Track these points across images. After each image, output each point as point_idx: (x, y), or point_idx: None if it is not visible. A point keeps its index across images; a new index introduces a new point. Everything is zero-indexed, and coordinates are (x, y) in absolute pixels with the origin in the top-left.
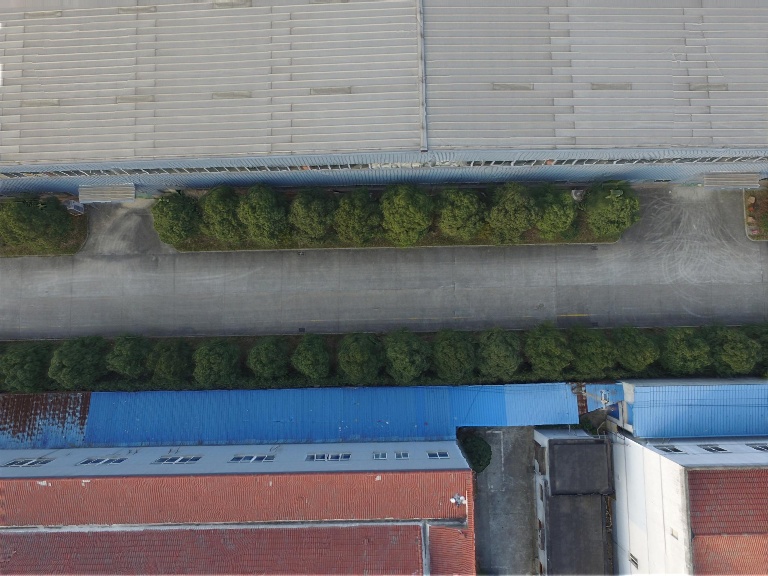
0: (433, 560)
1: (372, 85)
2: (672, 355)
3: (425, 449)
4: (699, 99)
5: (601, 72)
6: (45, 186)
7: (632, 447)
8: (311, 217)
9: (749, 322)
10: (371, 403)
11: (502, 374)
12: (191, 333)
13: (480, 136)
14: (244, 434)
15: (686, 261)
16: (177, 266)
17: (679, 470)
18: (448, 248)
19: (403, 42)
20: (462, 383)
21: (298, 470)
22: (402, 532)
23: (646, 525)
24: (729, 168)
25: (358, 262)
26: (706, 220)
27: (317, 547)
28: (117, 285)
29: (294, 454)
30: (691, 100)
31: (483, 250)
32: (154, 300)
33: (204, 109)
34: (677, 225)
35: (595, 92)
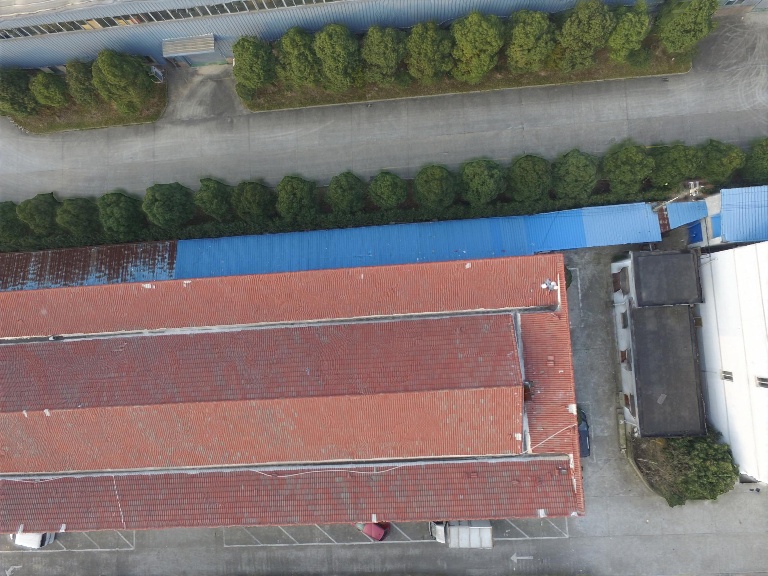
0: (526, 347)
1: None
2: (758, 161)
3: None
4: None
5: None
6: (131, 43)
7: (720, 258)
8: (385, 42)
9: None
10: (447, 235)
11: (580, 193)
12: None
13: None
14: None
15: (763, 86)
16: (251, 126)
17: None
18: (515, 90)
19: None
20: (537, 212)
21: None
22: (493, 322)
23: (741, 328)
24: None
25: (425, 110)
26: None
27: None
28: (196, 147)
29: None
30: None
31: (550, 90)
32: (231, 159)
33: None
34: (752, 51)
35: None
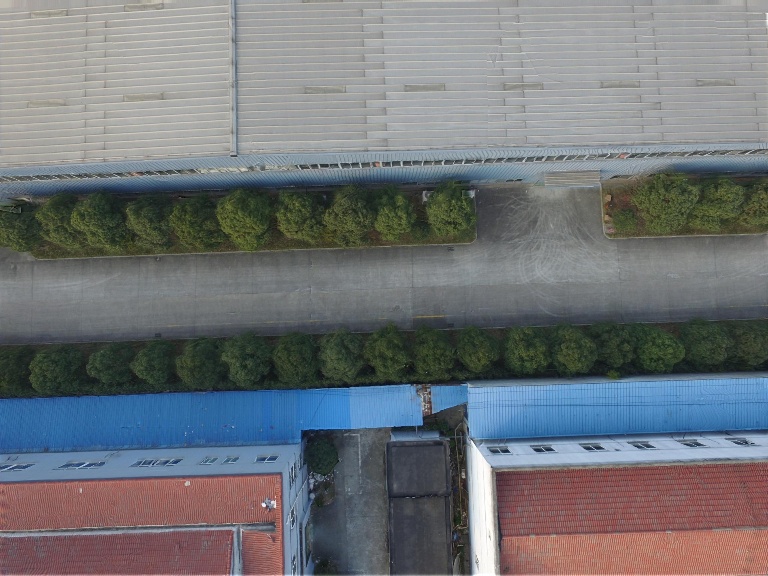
0: (245, 565)
1: (186, 91)
2: (511, 355)
3: (258, 453)
4: (514, 99)
5: (415, 73)
6: None
7: (473, 448)
8: (142, 223)
9: (600, 321)
10: (218, 408)
11: (343, 377)
12: (48, 340)
13: (302, 139)
14: (90, 440)
15: (543, 260)
16: (35, 274)
17: (489, 471)
18: (304, 251)
19: (220, 47)
20: (310, 386)
21: (111, 476)
22: (216, 537)
23: (480, 527)
24: (566, 167)
25: (215, 267)
26: (563, 219)
27: (132, 553)
28: None
29: (124, 460)
30: (506, 100)
31: (339, 253)
32: (12, 308)
33: (23, 118)
34: (534, 224)
35: (408, 94)
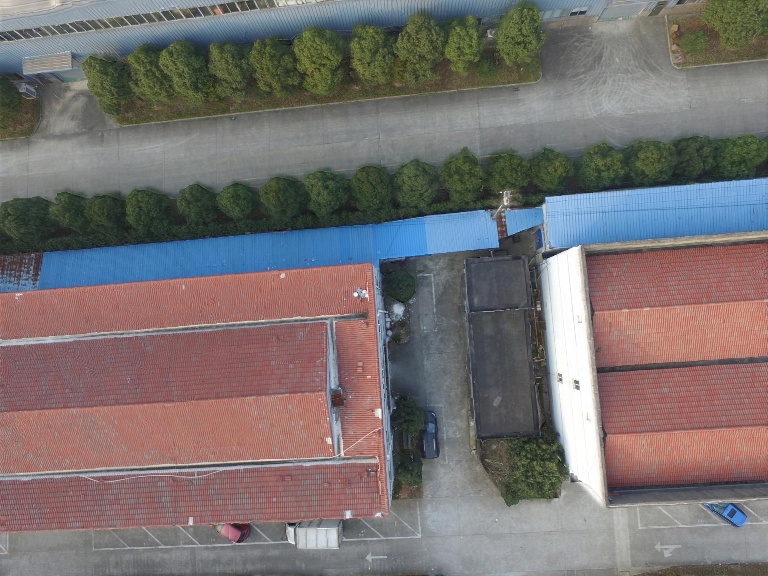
0: (340, 353)
1: None
2: (587, 169)
3: None
4: None
5: None
6: None
7: (551, 264)
8: (225, 59)
9: None
10: (298, 244)
11: (419, 202)
12: None
13: None
14: None
15: (610, 94)
16: (121, 139)
17: (578, 251)
18: (372, 101)
19: None
20: (385, 220)
21: None
22: (310, 330)
23: (564, 332)
24: None
25: (287, 122)
26: (629, 52)
27: None
28: (68, 161)
29: None
30: None
31: (406, 100)
32: (101, 172)
33: None
34: (599, 60)
35: None
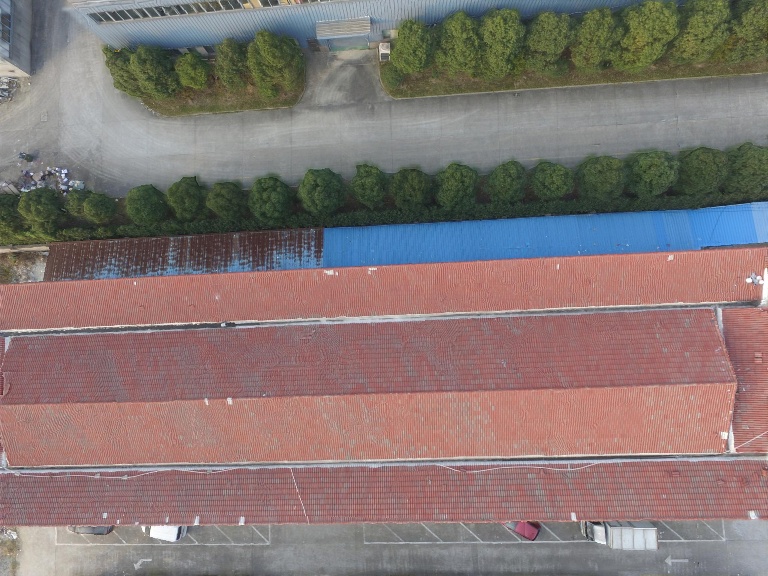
0: (730, 342)
1: None
2: None
3: None
4: None
5: None
6: (283, 25)
7: None
8: (559, 28)
9: None
10: (608, 228)
11: (754, 187)
12: None
13: None
14: None
15: None
16: (393, 113)
17: None
18: (669, 82)
19: None
20: (701, 206)
21: None
22: None
23: None
24: None
25: (575, 100)
26: None
27: None
28: (335, 134)
29: None
30: None
31: (706, 82)
32: (372, 146)
33: None
34: None
35: None
